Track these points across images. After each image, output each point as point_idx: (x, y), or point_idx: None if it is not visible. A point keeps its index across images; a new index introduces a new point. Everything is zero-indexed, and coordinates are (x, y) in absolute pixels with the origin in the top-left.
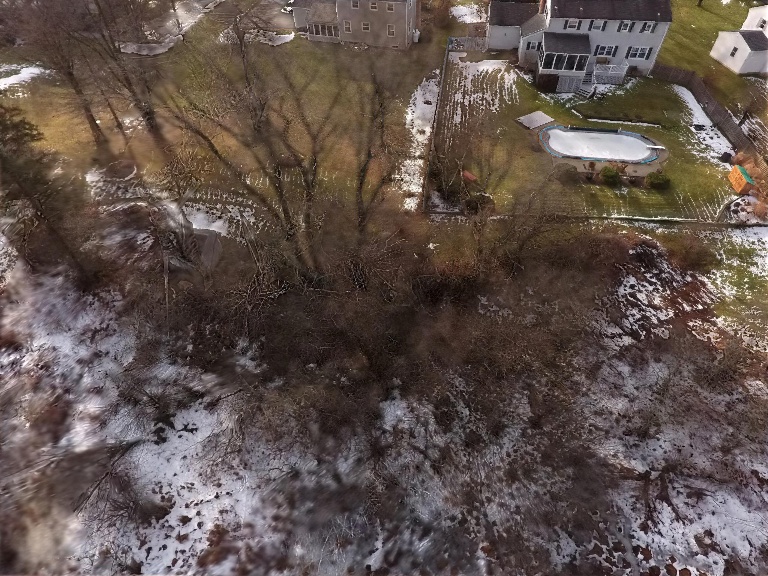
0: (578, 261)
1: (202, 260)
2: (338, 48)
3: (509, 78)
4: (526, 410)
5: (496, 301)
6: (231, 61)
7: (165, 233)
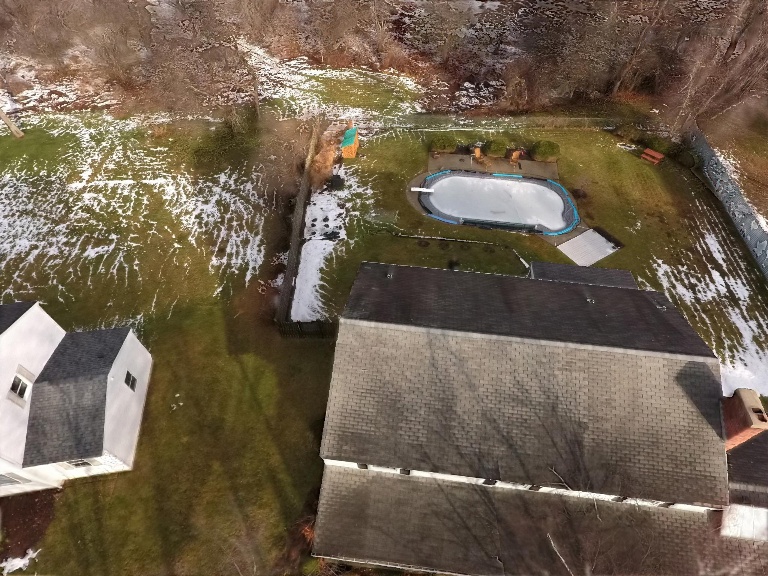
0: None
1: None
2: None
3: None
4: None
5: None
6: None
7: None
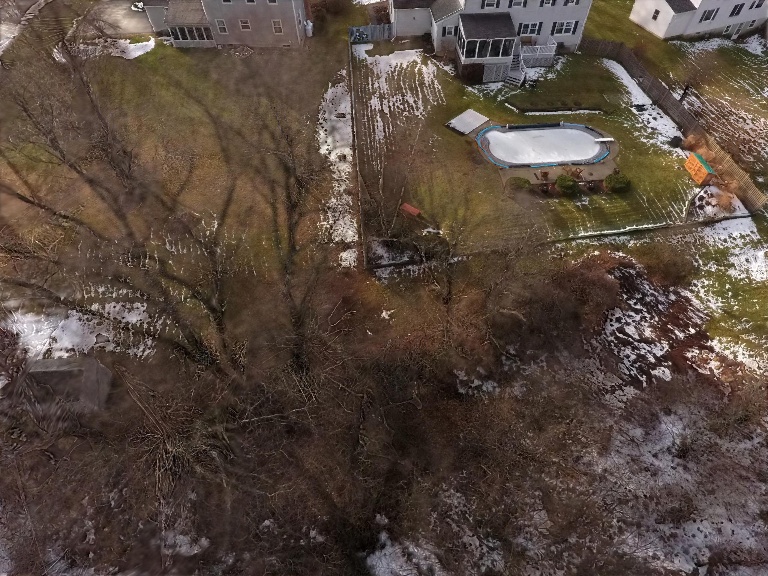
0: (557, 302)
1: (83, 404)
2: (215, 54)
3: (428, 72)
4: (543, 519)
5: (476, 374)
6: (75, 87)
7: (1, 435)
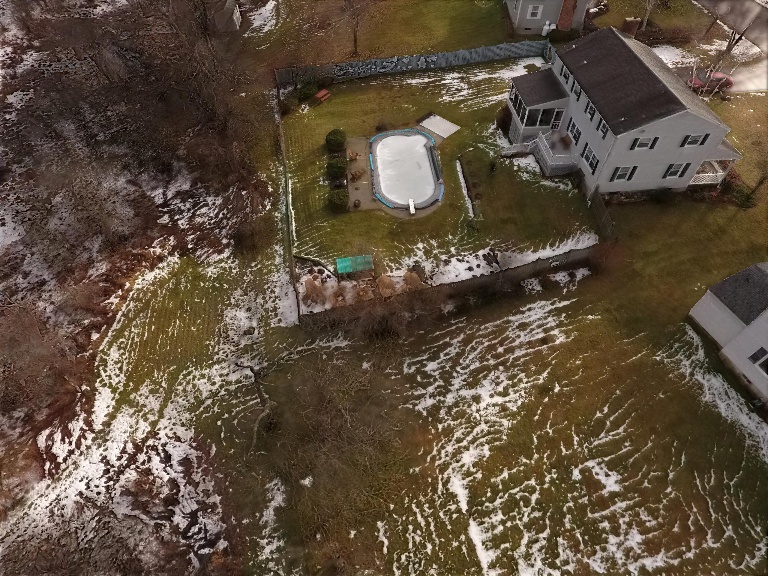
0: None
1: None
2: (495, 3)
3: (505, 96)
4: None
5: None
6: None
7: None
